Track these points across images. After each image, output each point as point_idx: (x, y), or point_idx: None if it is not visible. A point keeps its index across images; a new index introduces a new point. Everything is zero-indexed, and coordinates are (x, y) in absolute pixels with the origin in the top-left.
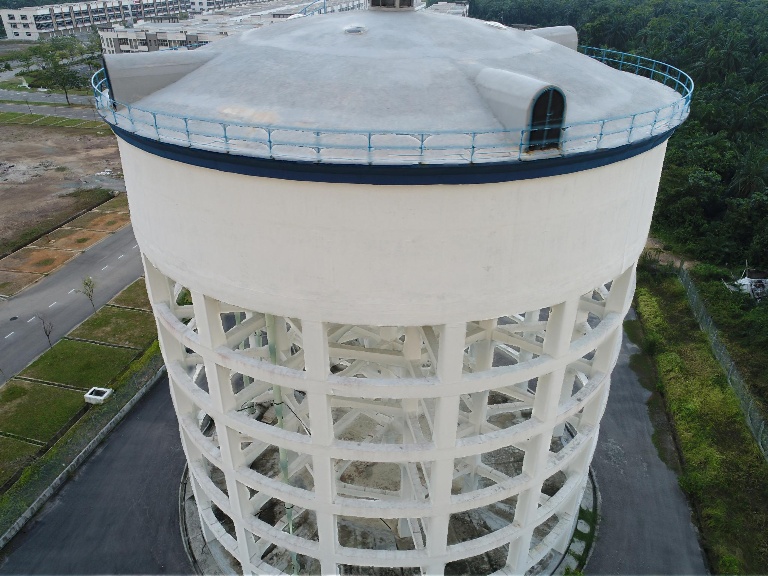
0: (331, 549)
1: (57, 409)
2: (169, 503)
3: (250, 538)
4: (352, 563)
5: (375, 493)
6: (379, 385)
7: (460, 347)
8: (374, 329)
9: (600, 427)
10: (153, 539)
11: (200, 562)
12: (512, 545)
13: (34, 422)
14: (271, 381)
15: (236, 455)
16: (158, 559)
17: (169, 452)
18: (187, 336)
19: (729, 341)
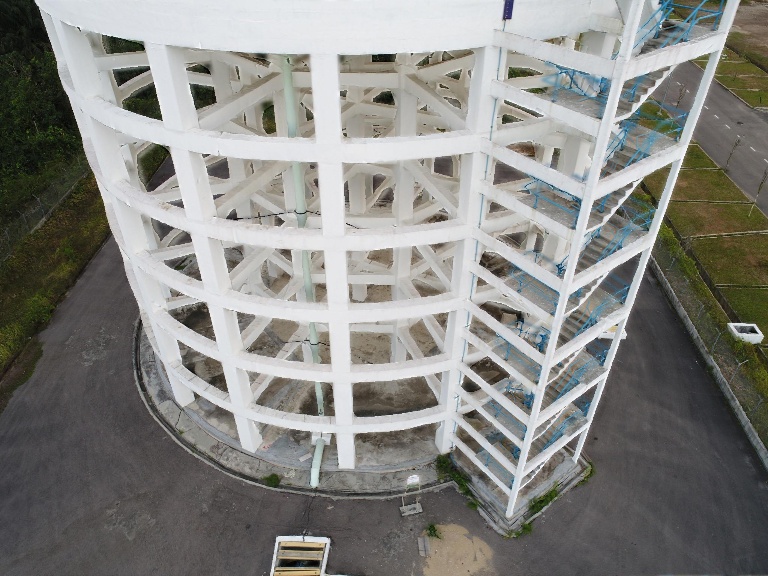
0: None
1: (765, 316)
2: None
3: None
4: None
5: None
6: None
7: None
8: (376, 165)
9: (91, 380)
10: None
11: None
12: None
13: (763, 300)
14: None
15: None
16: None
17: None
18: None
19: None
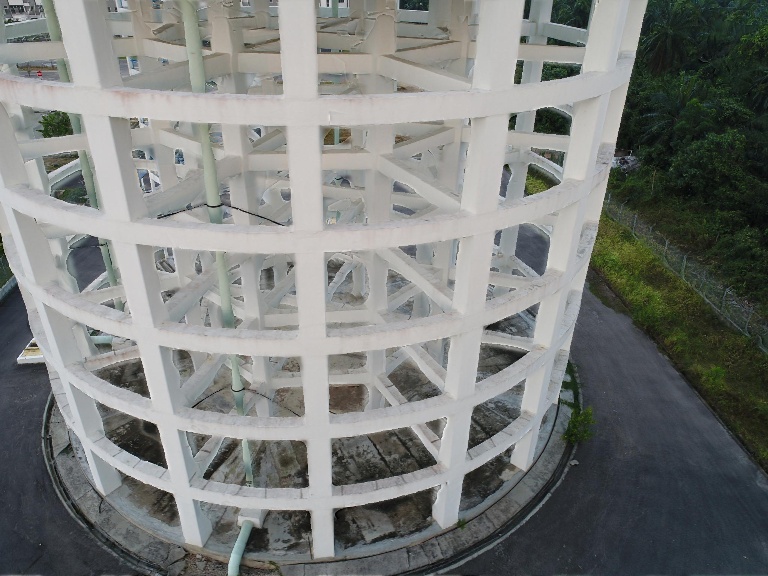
0: (324, 417)
1: None
2: (30, 465)
3: (186, 447)
4: (354, 433)
5: (335, 375)
6: (403, 96)
7: (517, 20)
8: None
9: None
10: (15, 515)
11: (100, 524)
12: (530, 382)
13: None
14: (221, 118)
15: (156, 303)
16: (30, 537)
17: (13, 406)
18: (45, 84)
19: (617, 207)
